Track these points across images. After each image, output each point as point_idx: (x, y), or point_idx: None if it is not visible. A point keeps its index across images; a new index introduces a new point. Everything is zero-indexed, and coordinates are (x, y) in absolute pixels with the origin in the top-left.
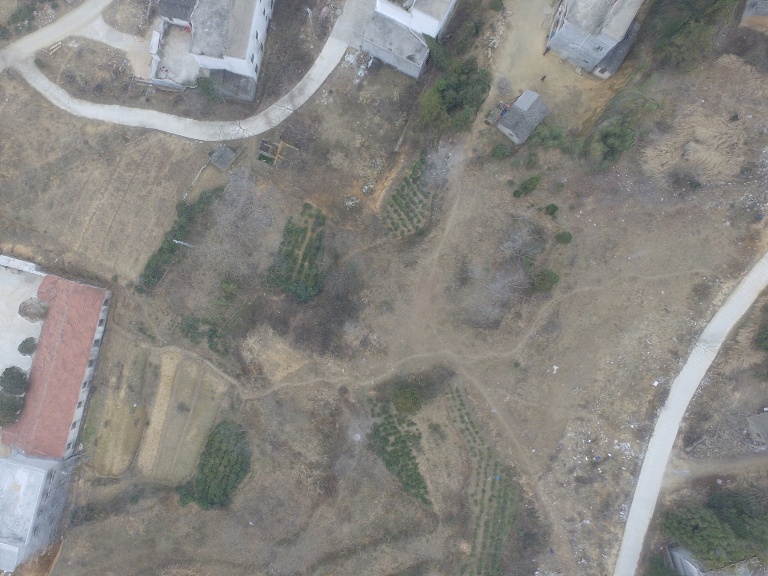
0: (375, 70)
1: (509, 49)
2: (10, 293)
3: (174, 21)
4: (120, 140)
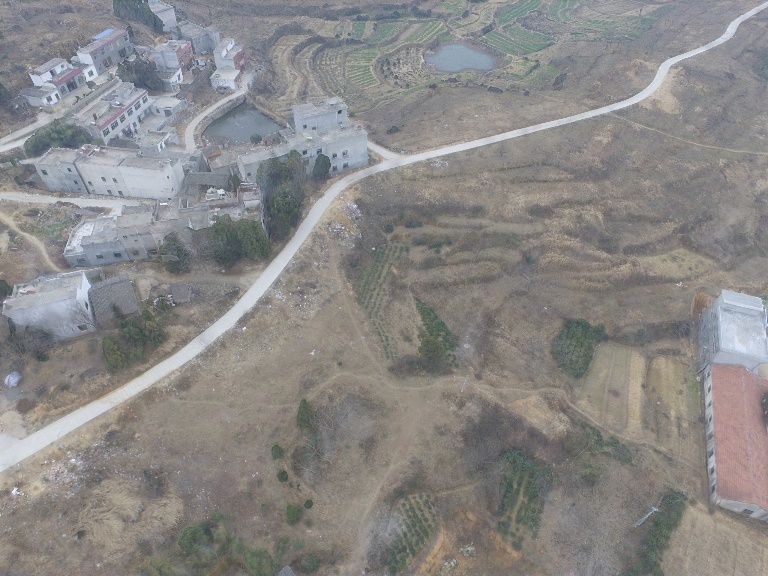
0: None
1: None
2: None
3: None
4: None
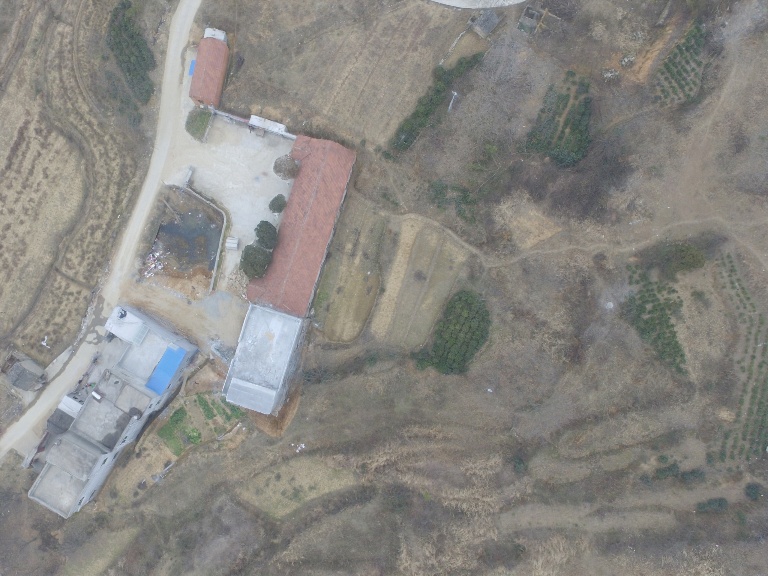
0: None
1: None
2: (253, 156)
3: None
4: (376, 6)
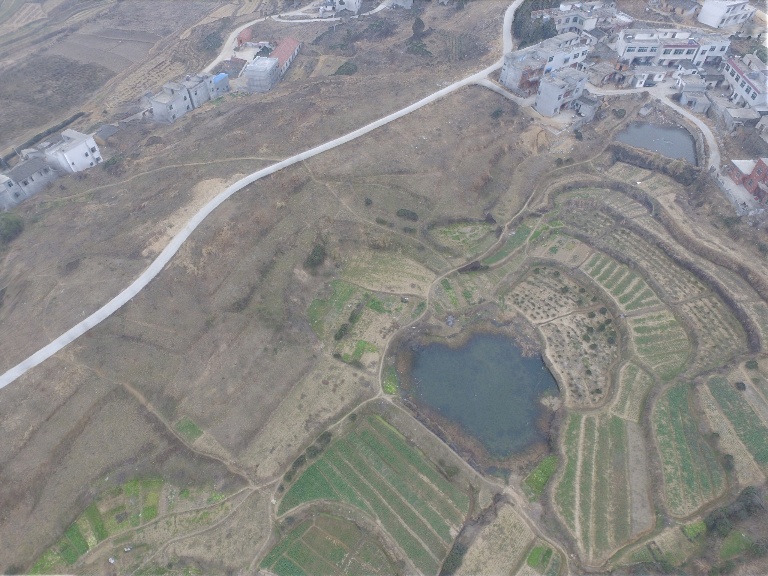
0: (396, 8)
1: None
2: None
3: (327, 8)
4: None
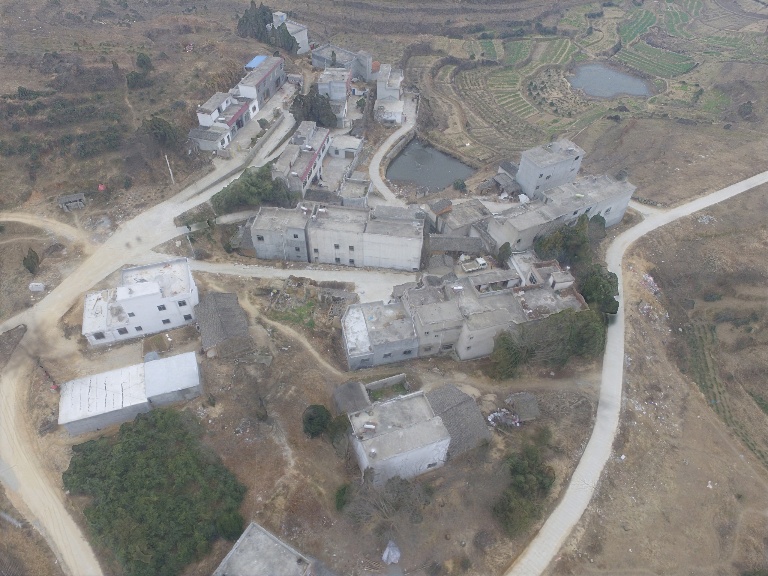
0: None
1: None
2: None
3: None
4: None
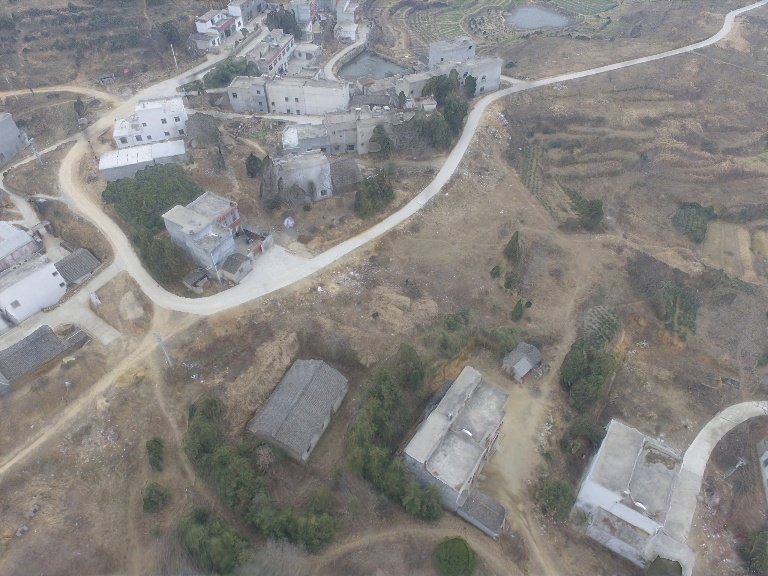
0: None
1: (534, 421)
2: None
3: None
4: None
